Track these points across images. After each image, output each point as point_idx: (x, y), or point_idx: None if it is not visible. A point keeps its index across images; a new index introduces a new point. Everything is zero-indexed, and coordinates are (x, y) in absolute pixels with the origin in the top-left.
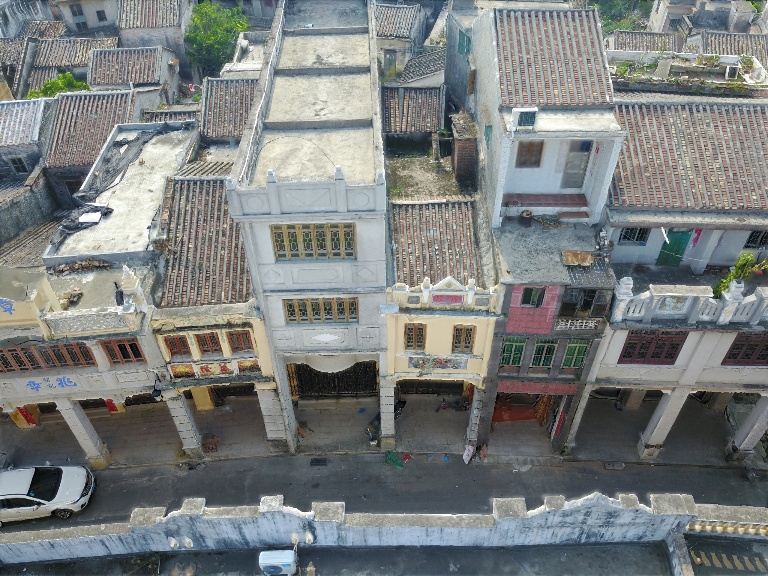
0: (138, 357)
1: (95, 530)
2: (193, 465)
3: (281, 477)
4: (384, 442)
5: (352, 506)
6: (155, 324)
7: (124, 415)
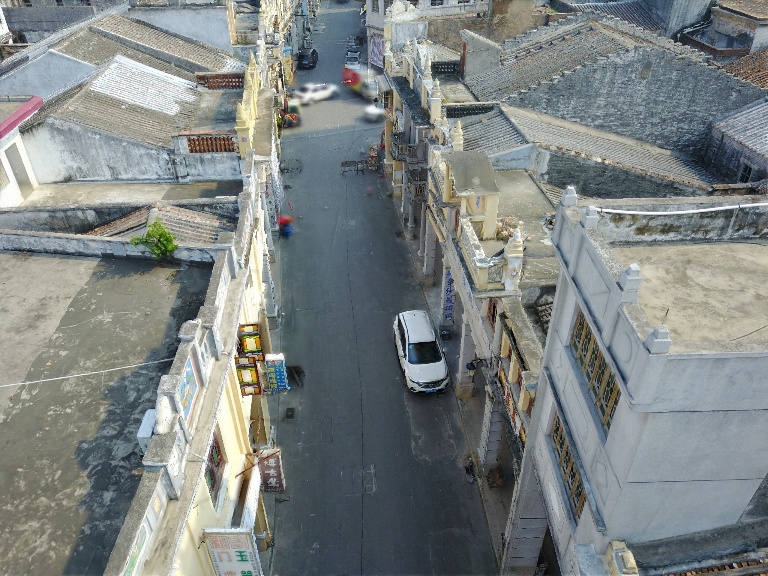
0: None
1: (212, 294)
2: (473, 471)
3: (467, 568)
4: None
5: None
6: None
7: None
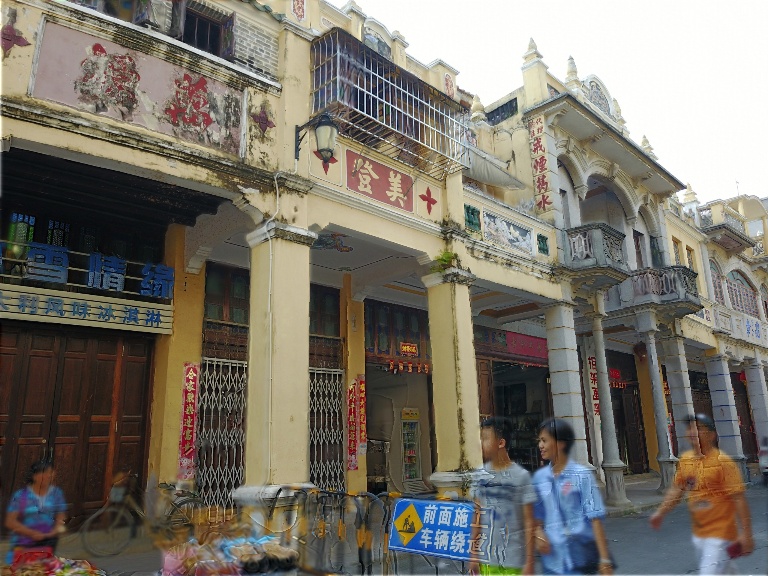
0: None
1: None
2: None
3: None
4: None
5: None
6: None
7: (709, 474)
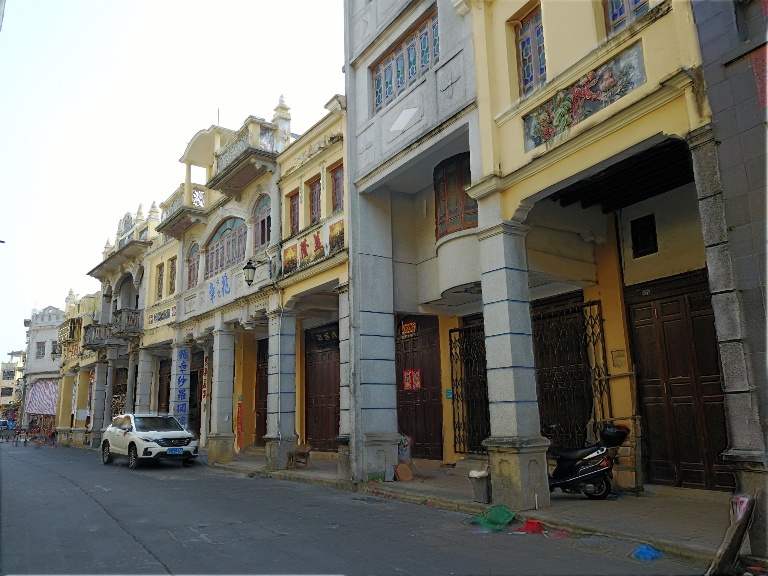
0: (269, 240)
1: None
2: None
3: (298, 494)
4: (497, 475)
5: (298, 523)
6: (283, 173)
7: None
